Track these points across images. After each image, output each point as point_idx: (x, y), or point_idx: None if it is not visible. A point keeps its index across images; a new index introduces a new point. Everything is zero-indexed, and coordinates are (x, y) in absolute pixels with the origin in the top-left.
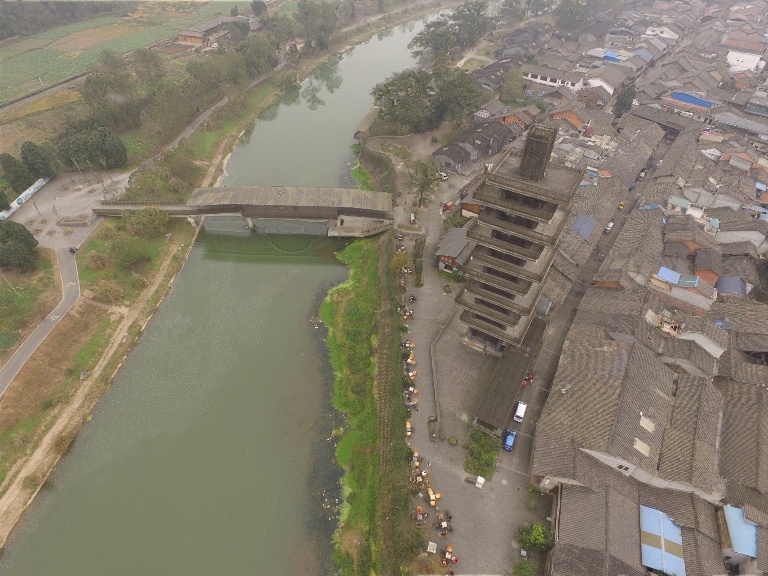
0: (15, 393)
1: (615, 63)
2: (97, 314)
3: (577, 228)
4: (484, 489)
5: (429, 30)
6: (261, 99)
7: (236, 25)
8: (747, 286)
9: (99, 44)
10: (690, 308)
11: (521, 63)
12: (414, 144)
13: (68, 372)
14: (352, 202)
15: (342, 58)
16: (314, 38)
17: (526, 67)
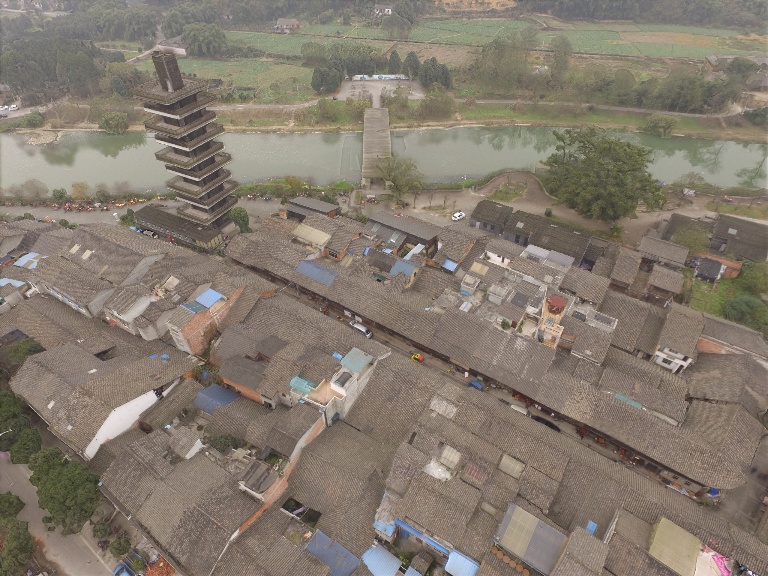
0: (237, 112)
1: None
2: (287, 118)
3: None
4: (115, 222)
5: None
6: (605, 121)
7: (734, 62)
8: None
9: (653, 43)
10: None
11: None
12: (533, 202)
13: (250, 120)
14: (370, 157)
15: None
16: None
17: None
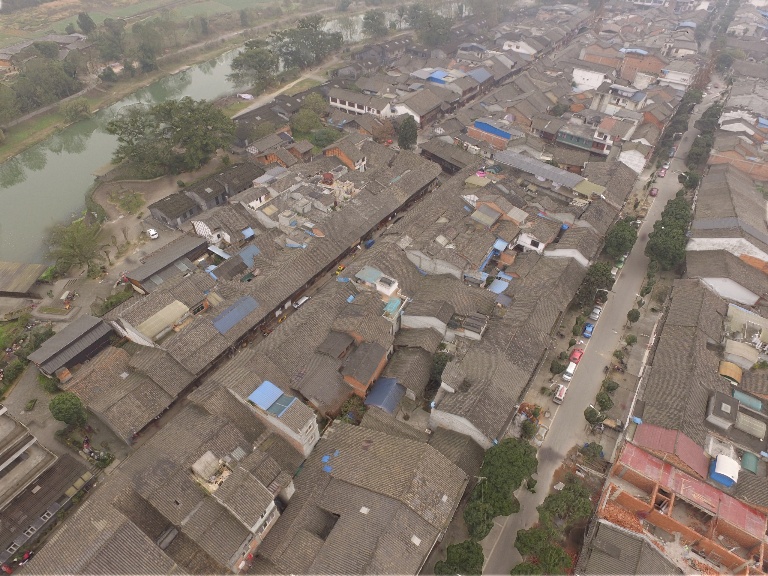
0: None
1: (439, 85)
2: None
3: (221, 316)
4: None
5: (253, 49)
6: (33, 133)
7: (37, 47)
8: (408, 392)
9: None
10: (290, 439)
11: (337, 86)
12: (155, 190)
13: None
14: None
15: (184, 79)
16: (135, 59)
17: (334, 92)
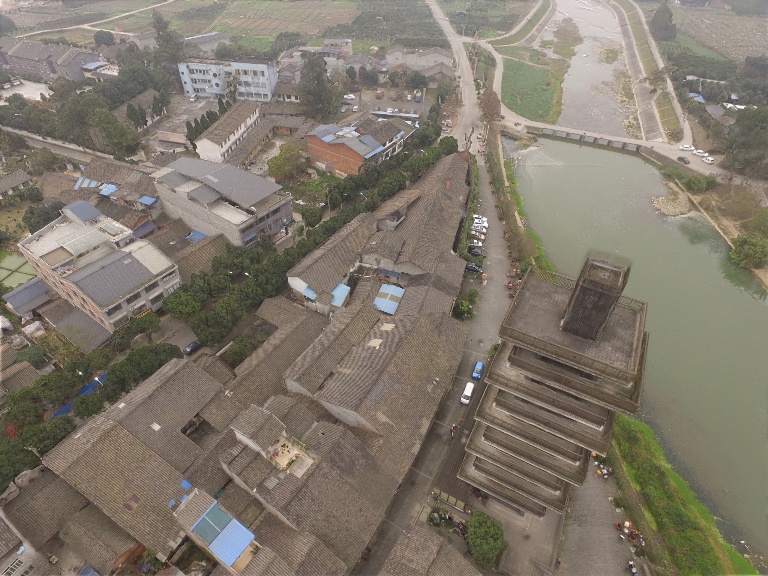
0: None
1: None
2: None
3: None
4: (497, 340)
5: None
6: None
7: None
8: None
9: None
10: None
11: None
12: None
13: None
14: None
15: None
16: None
17: None
